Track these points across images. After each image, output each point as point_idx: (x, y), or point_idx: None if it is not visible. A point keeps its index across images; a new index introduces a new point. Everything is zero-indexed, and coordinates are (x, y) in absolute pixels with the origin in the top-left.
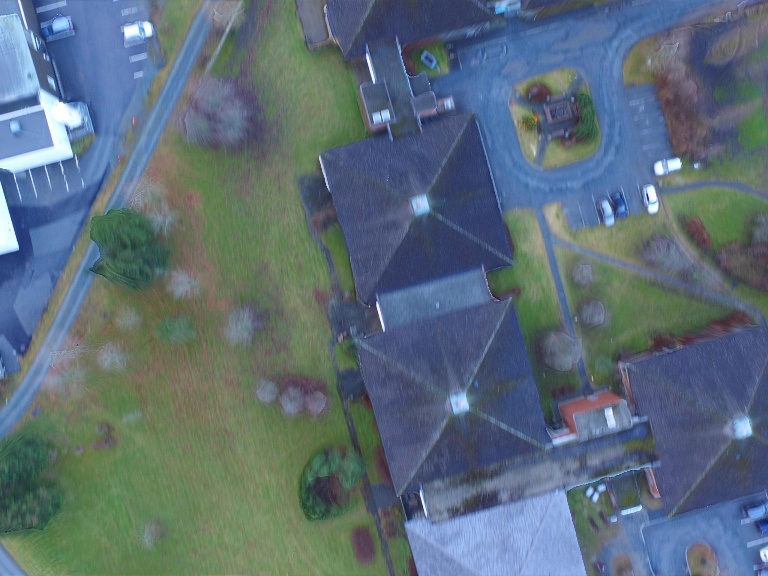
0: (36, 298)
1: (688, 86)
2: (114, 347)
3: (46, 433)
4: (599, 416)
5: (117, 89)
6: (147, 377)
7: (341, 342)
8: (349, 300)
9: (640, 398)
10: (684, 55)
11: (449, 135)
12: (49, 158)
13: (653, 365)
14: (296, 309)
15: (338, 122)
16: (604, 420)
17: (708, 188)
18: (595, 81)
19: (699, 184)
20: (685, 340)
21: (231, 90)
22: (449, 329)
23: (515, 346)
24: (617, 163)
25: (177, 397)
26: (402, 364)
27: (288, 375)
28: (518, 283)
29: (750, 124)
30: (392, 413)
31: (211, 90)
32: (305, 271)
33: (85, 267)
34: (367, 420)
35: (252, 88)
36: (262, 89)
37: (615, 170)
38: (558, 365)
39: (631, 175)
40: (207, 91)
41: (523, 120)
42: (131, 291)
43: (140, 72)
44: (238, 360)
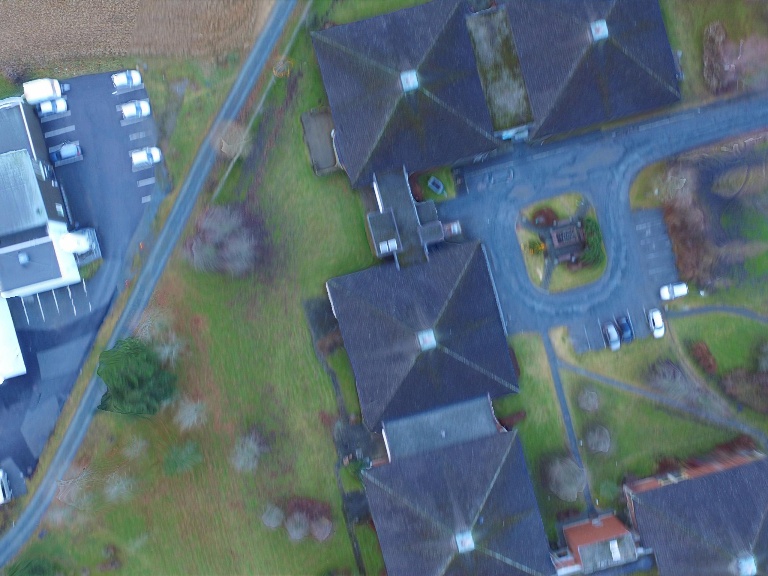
0: (43, 421)
1: (695, 214)
2: (121, 477)
3: (52, 555)
4: (604, 549)
5: (125, 213)
6: (153, 499)
7: (347, 465)
8: (355, 423)
9: (645, 530)
10: (691, 184)
11: (456, 265)
12: (57, 285)
13: (658, 498)
14: (302, 432)
15: (345, 246)
16: (609, 553)
17: (714, 313)
18: (602, 205)
19: (705, 309)
20: (690, 467)
21: (238, 217)
22: (455, 462)
23: (520, 479)
24: (623, 287)
25: (183, 519)
26: (408, 499)
27: (294, 498)
28: (524, 406)
29: (756, 252)
30: (397, 545)
31: (219, 219)
32: (311, 394)
33: (92, 391)
34: (372, 542)
35: (259, 212)
36: (269, 213)
37: (621, 294)
38: (563, 495)
39: (637, 299)
40: (215, 220)
41: (530, 245)
42: (138, 417)
43: (148, 196)
44: (244, 482)
